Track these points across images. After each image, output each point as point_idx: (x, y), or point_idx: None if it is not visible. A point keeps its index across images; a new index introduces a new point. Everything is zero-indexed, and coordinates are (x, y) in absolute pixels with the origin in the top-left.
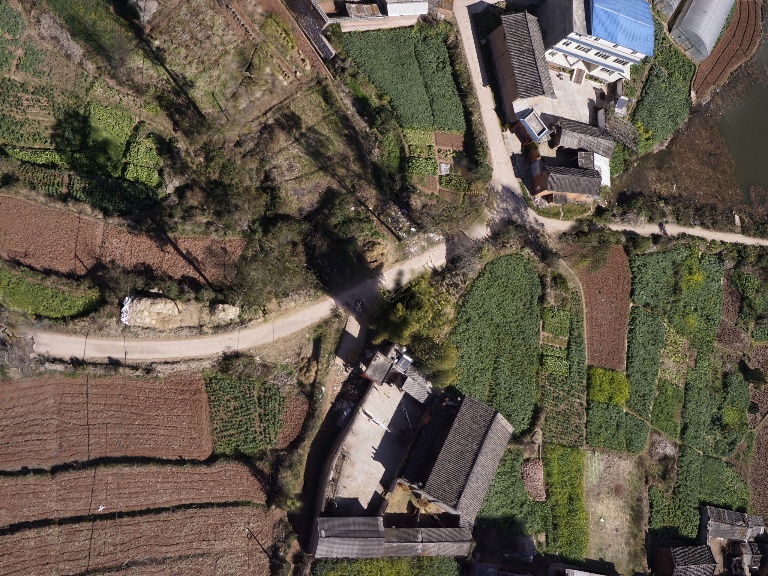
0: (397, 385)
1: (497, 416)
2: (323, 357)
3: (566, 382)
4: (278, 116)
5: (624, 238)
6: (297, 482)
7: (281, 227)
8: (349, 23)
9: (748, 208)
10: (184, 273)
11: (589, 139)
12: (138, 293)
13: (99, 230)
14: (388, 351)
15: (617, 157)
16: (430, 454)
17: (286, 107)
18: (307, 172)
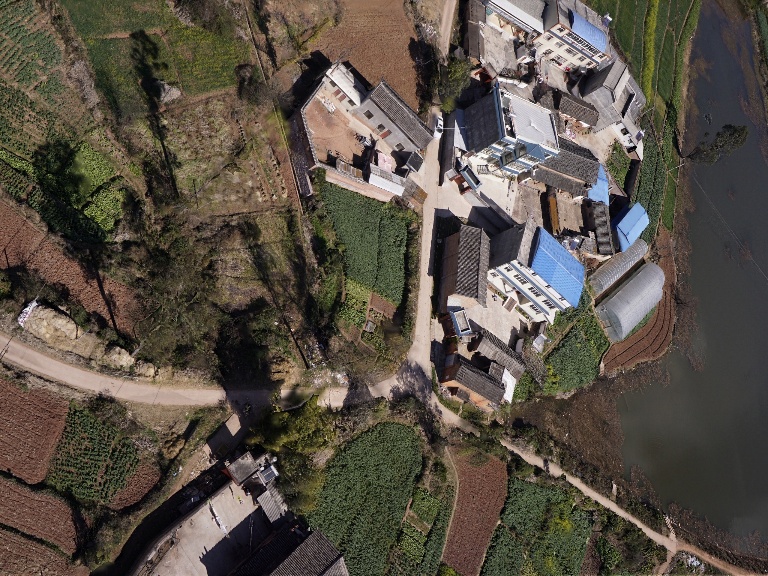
0: (253, 497)
1: (340, 560)
2: (194, 439)
3: (416, 569)
4: (242, 222)
5: (510, 457)
6: (114, 550)
7: (205, 309)
8: (334, 174)
9: (626, 484)
10: (97, 310)
11: (504, 356)
12: (47, 303)
13: (38, 239)
14: (258, 456)
15: (524, 385)
16: (260, 574)
17: (253, 218)
18: (248, 277)
